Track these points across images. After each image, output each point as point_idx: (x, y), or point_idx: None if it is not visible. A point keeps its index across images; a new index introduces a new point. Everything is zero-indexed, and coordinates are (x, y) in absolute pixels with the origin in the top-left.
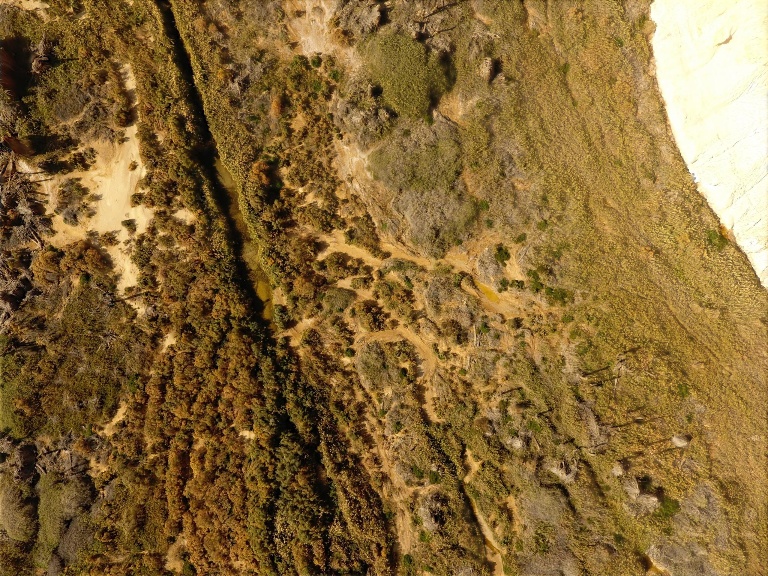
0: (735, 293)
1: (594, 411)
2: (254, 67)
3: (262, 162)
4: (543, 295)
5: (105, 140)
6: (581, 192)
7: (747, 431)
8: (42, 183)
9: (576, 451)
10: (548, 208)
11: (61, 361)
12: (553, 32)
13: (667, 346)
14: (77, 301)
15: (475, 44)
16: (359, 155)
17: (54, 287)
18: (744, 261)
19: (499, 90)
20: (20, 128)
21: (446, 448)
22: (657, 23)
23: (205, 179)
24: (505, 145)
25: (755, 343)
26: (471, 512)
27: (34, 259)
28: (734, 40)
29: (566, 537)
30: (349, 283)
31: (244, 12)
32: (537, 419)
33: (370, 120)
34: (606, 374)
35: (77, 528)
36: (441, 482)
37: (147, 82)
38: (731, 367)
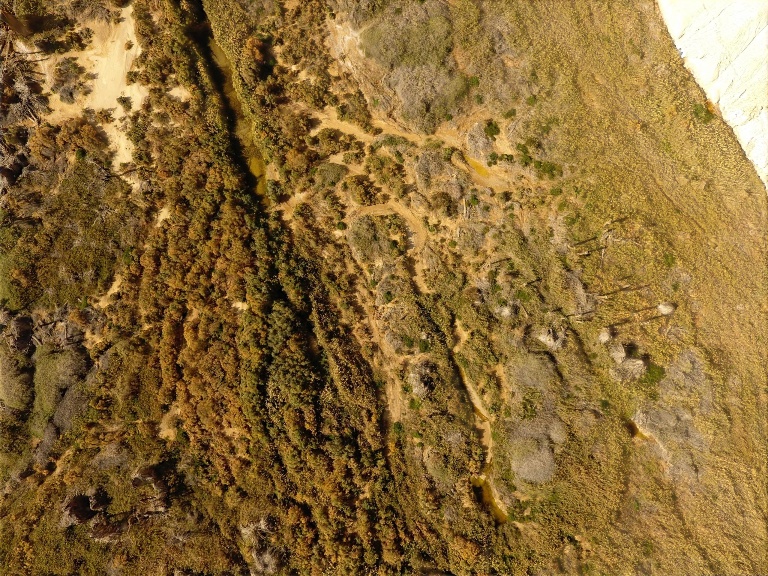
0: (721, 165)
1: (581, 280)
2: None
3: (256, 38)
4: (532, 168)
5: (101, 20)
6: (570, 67)
7: (732, 300)
8: (39, 63)
9: (564, 319)
10: (537, 84)
11: (57, 234)
12: None
13: (654, 218)
14: (73, 176)
15: None
16: (351, 34)
17: (50, 163)
18: (730, 133)
19: None
20: (17, 7)
21: (436, 317)
22: None
23: (199, 56)
24: (495, 22)
25: (740, 214)
26: (460, 380)
27: (31, 136)
28: None
29: (553, 402)
30: (341, 158)
31: None
32: (525, 288)
33: None
34: (593, 244)
35: (72, 395)
36: (431, 351)
37: None
38: (717, 239)
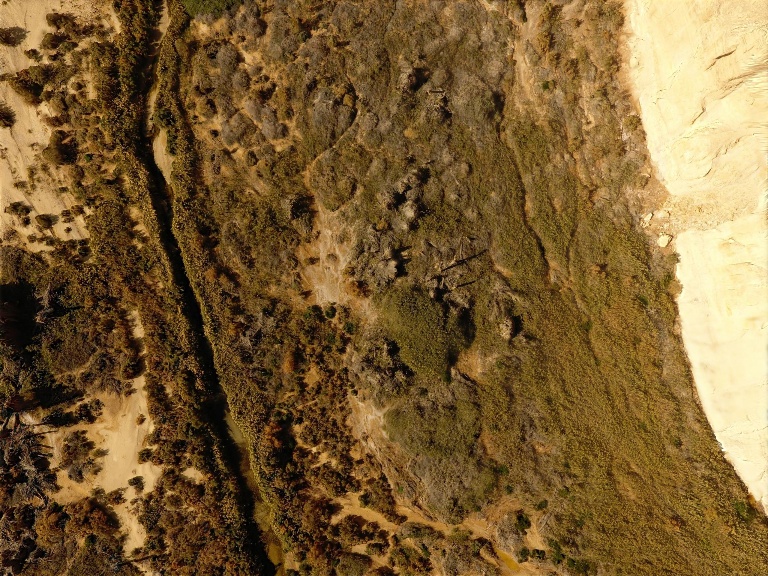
0: (764, 571)
1: None
2: (266, 320)
3: (274, 425)
4: (565, 566)
5: (112, 392)
6: (604, 459)
7: None
8: (46, 435)
9: None
10: (570, 473)
11: None
12: (575, 288)
13: None
14: (82, 564)
15: (495, 303)
16: (374, 413)
17: (58, 547)
18: None
19: (519, 349)
20: (24, 381)
21: None
22: (683, 284)
23: (215, 438)
24: (526, 407)
25: None
26: None
27: (38, 518)
28: (766, 331)
29: None
30: (364, 548)
31: (256, 259)
32: None
33: (386, 382)
34: None
35: None
36: None
37: (155, 334)
38: None
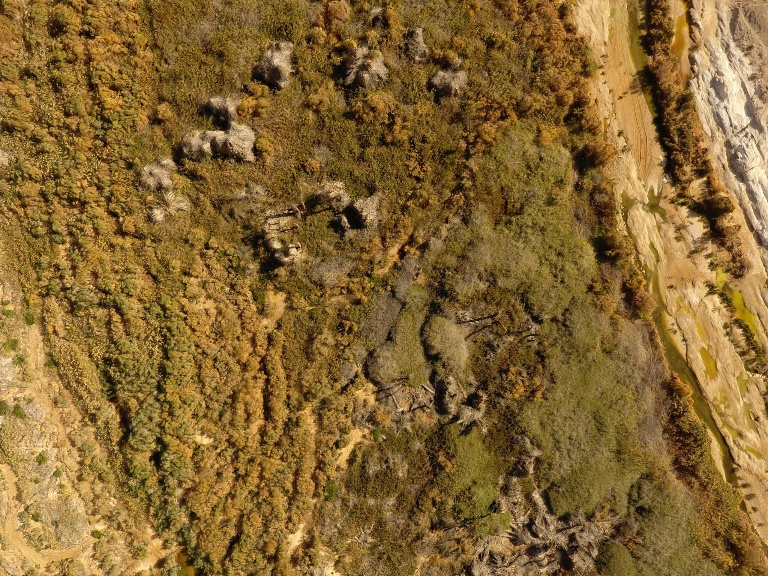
0: None
1: None
2: None
3: None
4: None
5: None
6: None
7: None
8: None
9: None
10: None
11: (412, 512)
12: None
13: None
14: None
15: None
16: None
17: None
18: None
19: None
20: None
21: None
22: None
23: None
24: None
25: None
26: None
27: None
28: None
29: None
30: None
31: None
32: None
33: None
34: None
35: (376, 335)
36: None
37: None
38: None
